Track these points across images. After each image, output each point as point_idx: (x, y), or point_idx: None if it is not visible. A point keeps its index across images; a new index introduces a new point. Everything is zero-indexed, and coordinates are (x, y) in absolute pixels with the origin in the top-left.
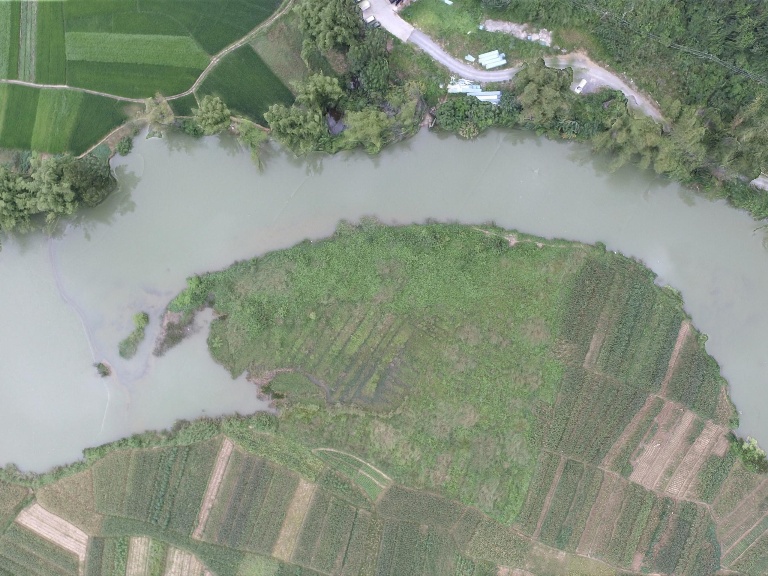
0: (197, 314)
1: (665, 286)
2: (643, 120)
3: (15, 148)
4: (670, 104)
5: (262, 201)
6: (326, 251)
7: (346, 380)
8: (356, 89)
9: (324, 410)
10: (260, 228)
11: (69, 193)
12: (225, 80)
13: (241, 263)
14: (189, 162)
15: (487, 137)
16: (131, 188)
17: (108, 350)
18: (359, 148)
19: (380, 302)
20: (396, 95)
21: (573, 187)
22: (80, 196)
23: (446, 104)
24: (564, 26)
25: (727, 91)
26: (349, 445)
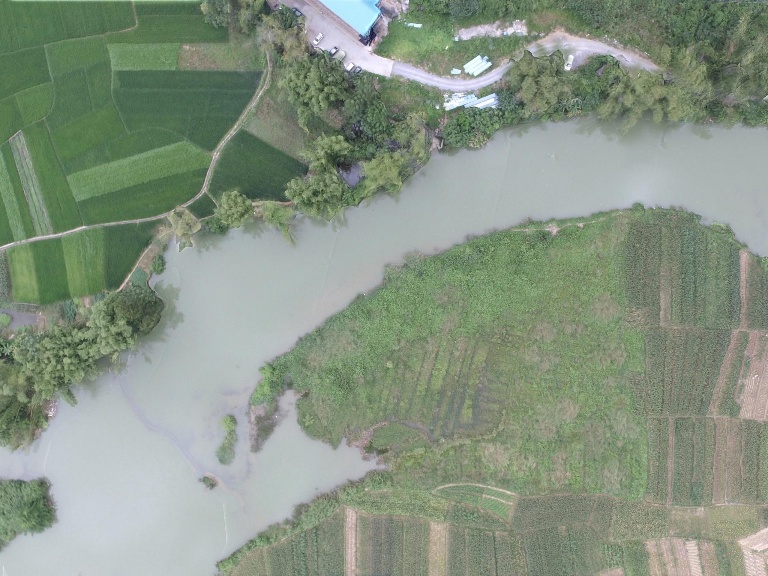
0: (280, 400)
1: (712, 224)
2: (644, 77)
3: (56, 302)
4: (659, 51)
5: (304, 272)
6: (382, 299)
7: (441, 415)
8: (359, 137)
9: (430, 450)
10: (311, 298)
11: (127, 329)
12: (232, 170)
13: (305, 338)
14: (220, 258)
15: (495, 139)
16: (174, 300)
17: (207, 462)
18: (380, 192)
19: (449, 330)
20: (402, 132)
21: (592, 159)
22: (136, 327)
23: (451, 124)
24: (535, 11)
25: (710, 21)
26: (465, 475)
